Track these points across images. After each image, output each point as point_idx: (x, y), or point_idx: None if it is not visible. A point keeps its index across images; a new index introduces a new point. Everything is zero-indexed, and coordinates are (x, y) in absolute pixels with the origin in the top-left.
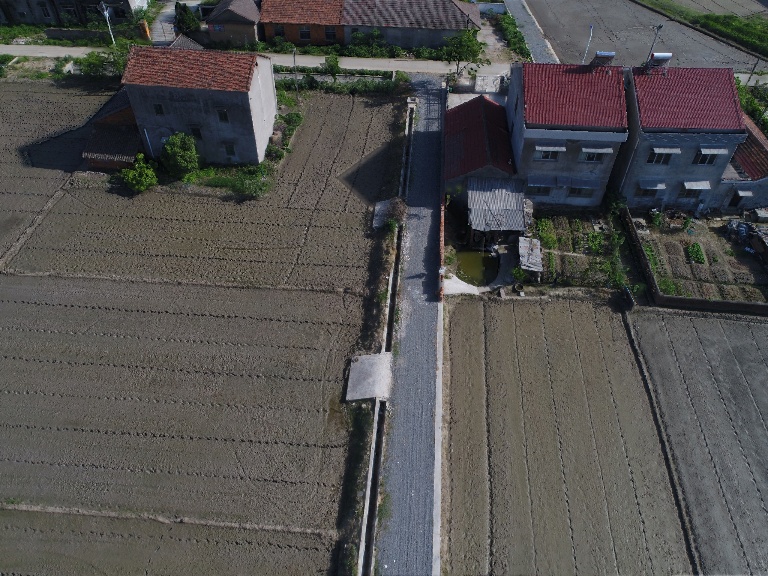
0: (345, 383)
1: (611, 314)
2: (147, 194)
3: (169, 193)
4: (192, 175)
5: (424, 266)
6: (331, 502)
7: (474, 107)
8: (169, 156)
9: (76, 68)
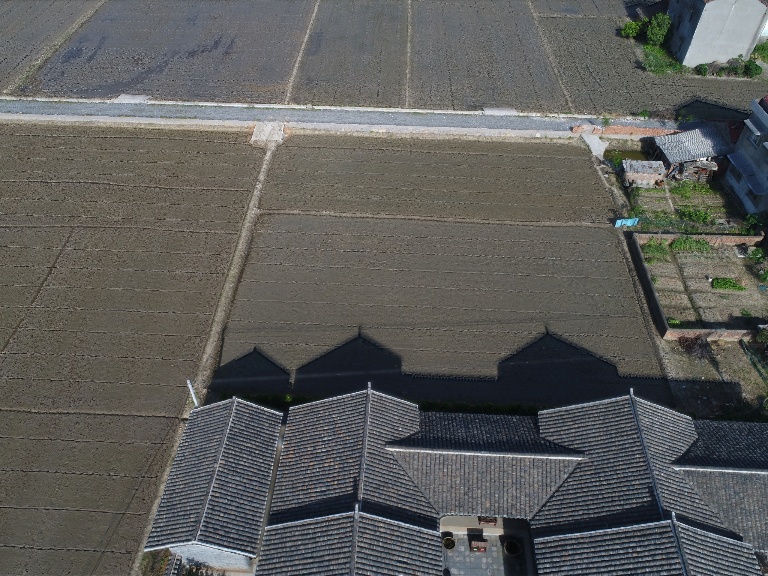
0: None
1: (606, 217)
2: (623, 40)
3: (630, 46)
4: (652, 47)
5: None
6: None
7: None
8: None
9: None
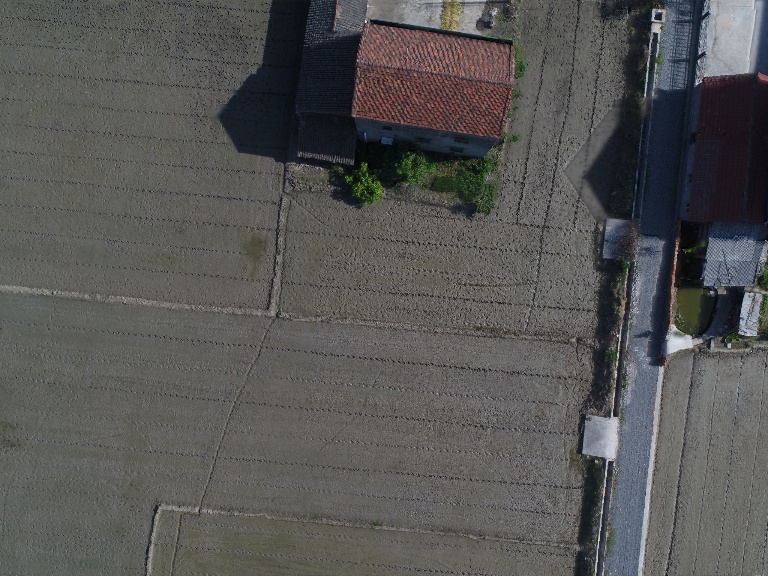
0: (581, 437)
1: None
2: None
3: (395, 200)
4: None
5: (651, 322)
6: (574, 527)
7: (743, 95)
8: None
9: None
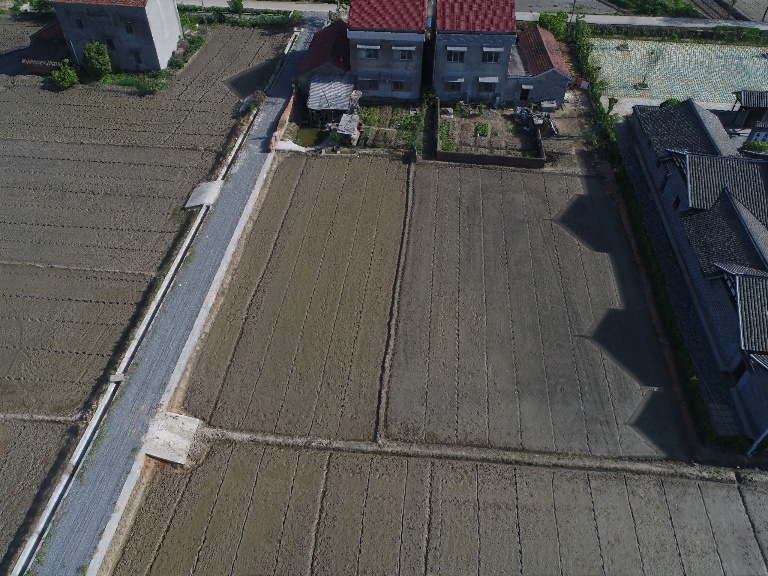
0: (187, 199)
1: (400, 165)
2: (70, 90)
3: (88, 90)
4: (107, 77)
5: (267, 132)
6: (157, 259)
7: (333, 27)
8: (87, 60)
9: (32, 8)
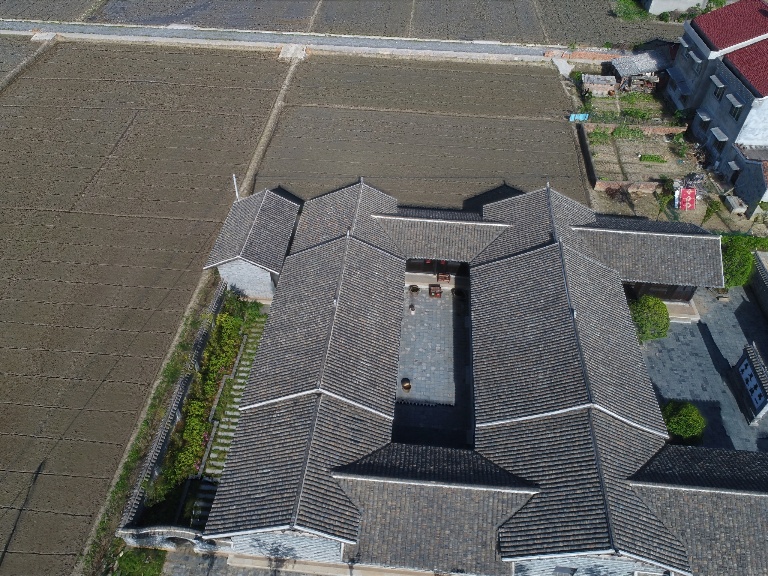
0: None
1: (563, 115)
2: None
3: None
4: (625, 0)
5: None
6: None
7: None
8: None
9: None
